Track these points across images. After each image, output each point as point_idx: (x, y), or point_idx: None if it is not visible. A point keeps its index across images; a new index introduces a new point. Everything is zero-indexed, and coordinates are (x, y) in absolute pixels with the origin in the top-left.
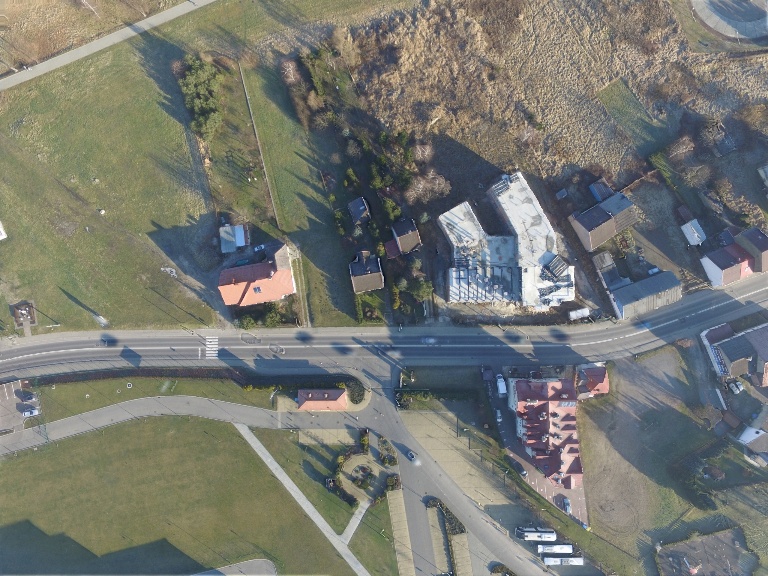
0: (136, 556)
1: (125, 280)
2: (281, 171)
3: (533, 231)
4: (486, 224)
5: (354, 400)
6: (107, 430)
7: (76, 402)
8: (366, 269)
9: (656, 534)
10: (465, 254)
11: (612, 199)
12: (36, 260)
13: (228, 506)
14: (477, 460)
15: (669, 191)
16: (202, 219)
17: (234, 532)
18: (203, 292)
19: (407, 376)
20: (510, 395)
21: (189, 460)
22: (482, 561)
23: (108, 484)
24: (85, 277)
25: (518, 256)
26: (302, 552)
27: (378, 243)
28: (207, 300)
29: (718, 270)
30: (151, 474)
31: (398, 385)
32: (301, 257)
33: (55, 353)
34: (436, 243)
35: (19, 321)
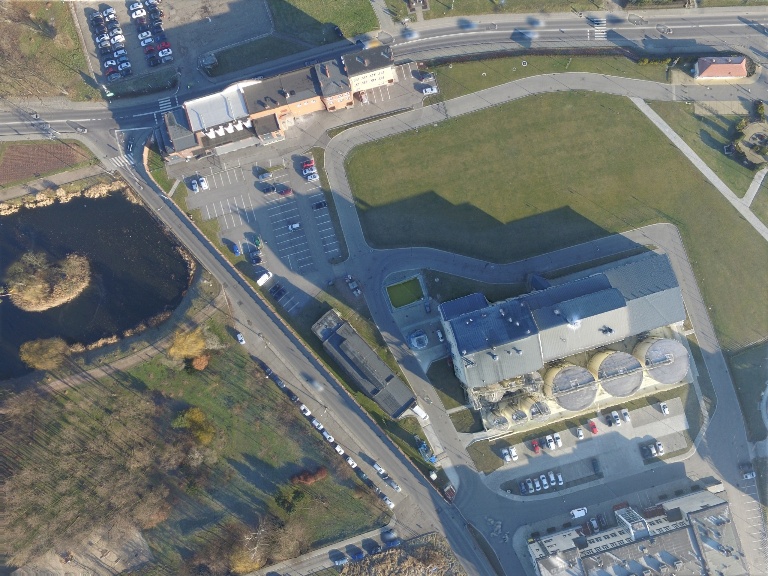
0: (541, 223)
1: None
2: None
3: None
4: None
5: (747, 72)
6: (505, 106)
7: (473, 80)
8: None
9: None
10: None
11: None
12: None
13: (629, 174)
14: None
15: None
16: None
17: (636, 198)
18: None
19: None
20: None
21: (588, 132)
22: None
23: (509, 156)
24: None
25: None
26: (704, 215)
27: None
28: None
29: None
30: (551, 146)
31: None
32: None
33: (447, 37)
34: None
35: (411, 6)
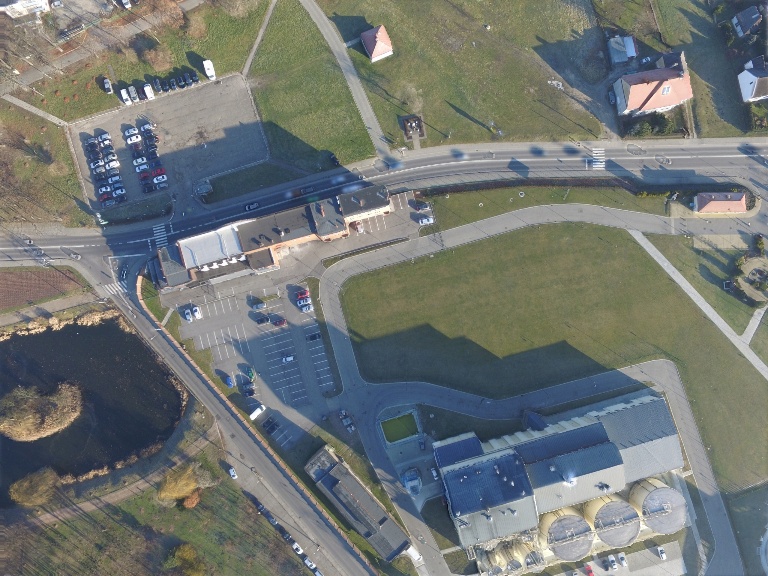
0: (537, 357)
1: (513, 93)
2: None
3: None
4: None
5: (747, 206)
6: (501, 237)
7: (470, 211)
8: None
9: None
10: None
11: None
12: (423, 75)
13: (627, 309)
14: None
15: None
16: (586, 33)
17: (634, 334)
18: (589, 104)
19: None
20: None
21: (585, 265)
22: None
23: (506, 289)
24: (473, 91)
25: None
26: (703, 352)
27: None
28: (594, 112)
29: None
30: (548, 279)
31: None
32: None
33: (444, 165)
34: None
35: (408, 134)
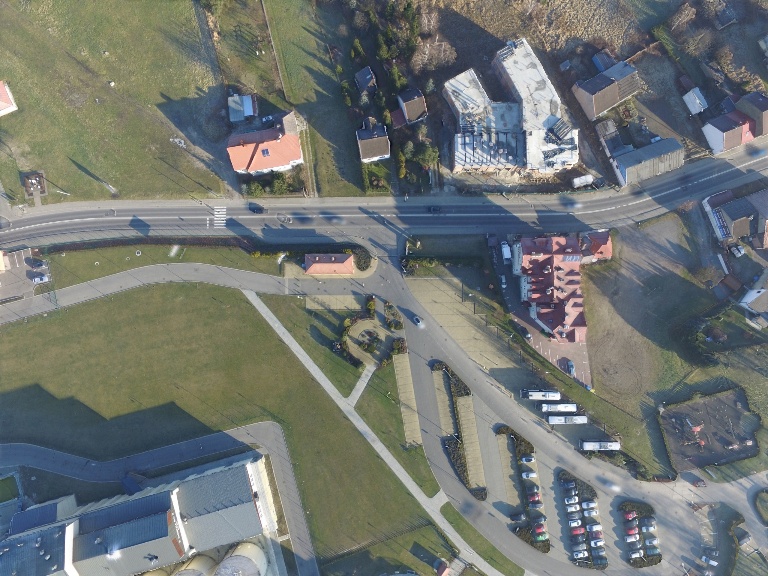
0: (145, 419)
1: (134, 150)
2: (289, 45)
3: (537, 95)
4: (491, 95)
5: (360, 267)
6: (116, 296)
7: (85, 269)
8: (373, 134)
9: (659, 396)
10: (470, 120)
11: (615, 67)
12: (46, 131)
13: (236, 370)
14: (482, 324)
15: (671, 63)
16: (211, 91)
17: (242, 395)
18: (211, 162)
19: (413, 244)
20: (515, 260)
21: (197, 325)
22: (487, 423)
23: (117, 349)
24: (95, 147)
25: (523, 120)
26: (309, 414)
27: (384, 110)
28: (215, 170)
29: (720, 133)
30: (160, 339)
31: (404, 253)
32: (308, 128)
33: (65, 223)
34: (441, 114)
35: (29, 191)
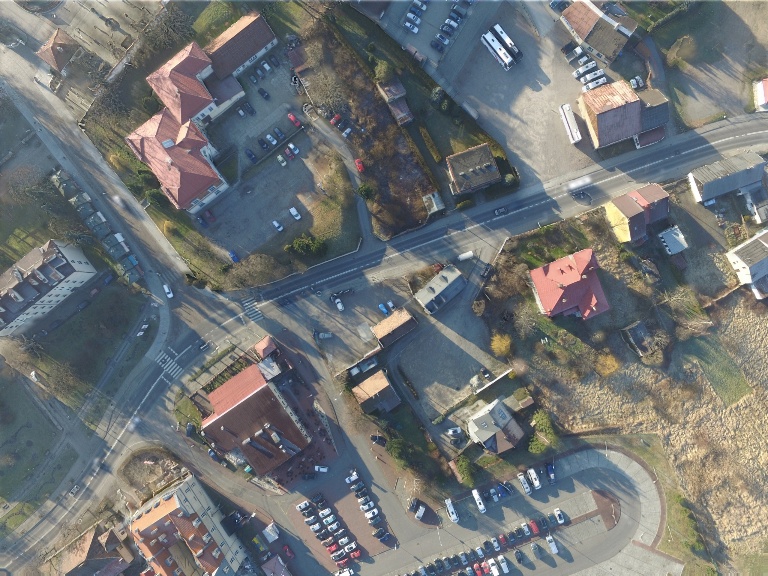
0: None
1: None
2: None
3: None
4: None
5: None
6: None
7: None
8: None
9: None
10: None
11: (763, 274)
12: None
13: None
14: None
15: None
16: None
17: None
18: None
19: None
20: None
21: None
22: None
23: None
24: None
25: None
26: None
27: None
28: None
29: None
30: None
31: None
32: None
33: None
34: None
35: None
